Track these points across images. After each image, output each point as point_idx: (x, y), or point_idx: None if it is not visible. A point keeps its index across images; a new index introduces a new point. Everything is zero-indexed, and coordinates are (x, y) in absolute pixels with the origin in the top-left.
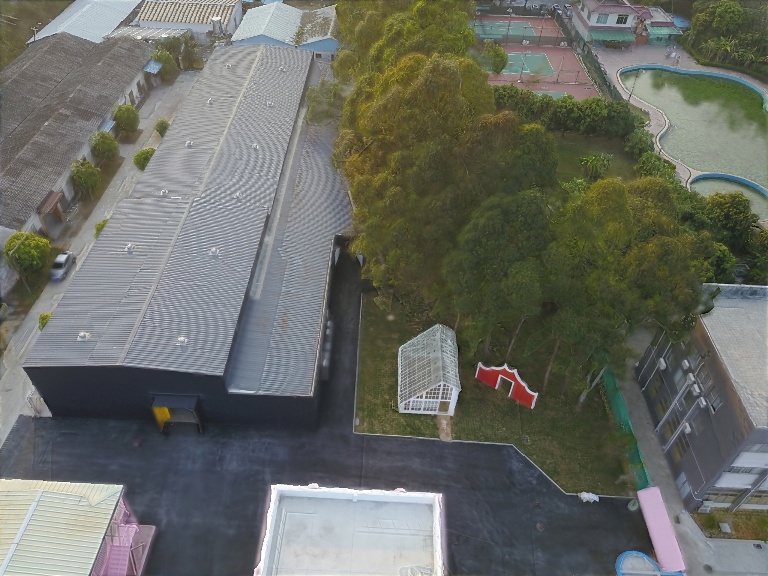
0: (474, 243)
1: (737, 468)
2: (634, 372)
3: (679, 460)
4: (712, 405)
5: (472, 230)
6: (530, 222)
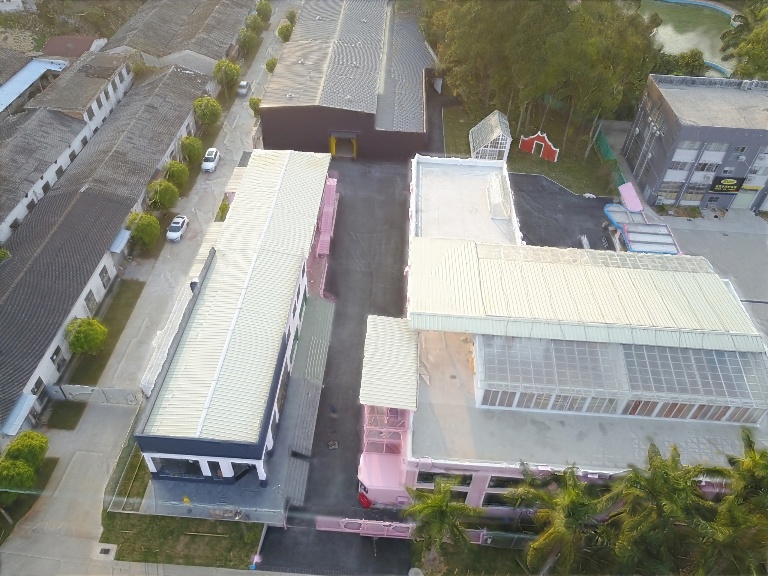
0: (526, 27)
1: (676, 165)
2: (621, 151)
3: (645, 180)
4: (663, 132)
5: (525, 19)
6: (559, 11)
